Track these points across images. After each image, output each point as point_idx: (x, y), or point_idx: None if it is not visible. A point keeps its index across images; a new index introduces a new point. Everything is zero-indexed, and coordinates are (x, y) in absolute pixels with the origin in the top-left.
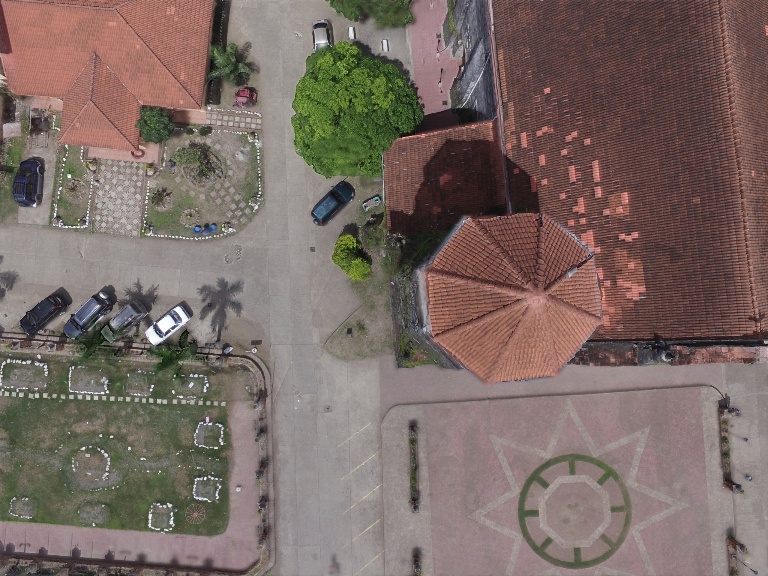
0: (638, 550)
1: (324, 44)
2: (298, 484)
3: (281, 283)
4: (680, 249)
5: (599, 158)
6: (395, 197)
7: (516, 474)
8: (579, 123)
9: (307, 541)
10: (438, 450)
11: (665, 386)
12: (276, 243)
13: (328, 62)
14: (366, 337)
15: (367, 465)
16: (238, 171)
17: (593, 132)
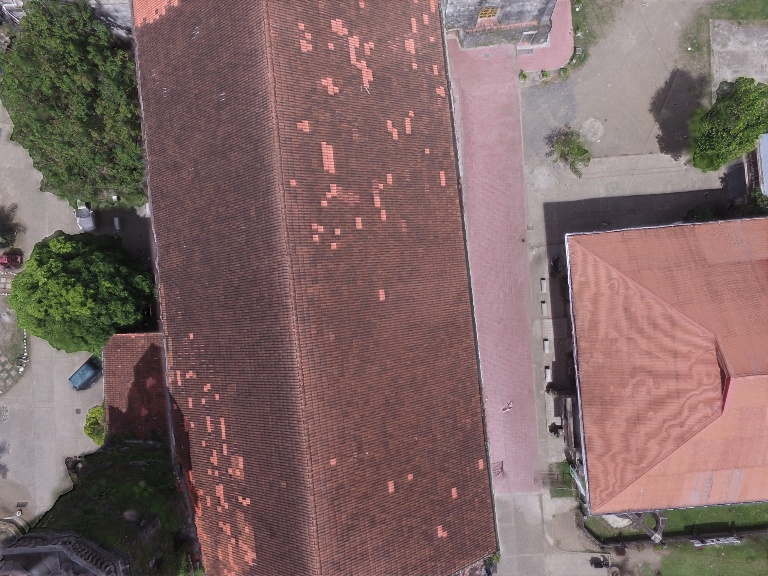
0: None
1: (83, 210)
2: None
3: (46, 445)
4: (275, 527)
5: (224, 416)
6: (111, 393)
7: None
8: (211, 376)
9: None
10: None
11: None
12: (42, 405)
13: (31, 266)
14: None
15: None
16: (4, 332)
17: (220, 389)
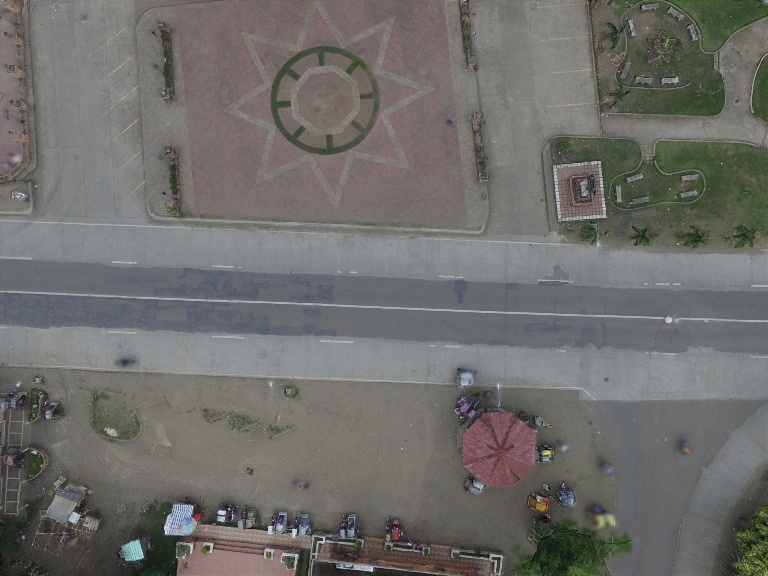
0: (387, 134)
1: None
2: (57, 89)
3: None
4: None
5: None
6: None
7: (268, 68)
8: None
9: (68, 143)
10: (191, 49)
11: None
12: None
13: None
14: None
15: (124, 68)
16: None
17: None
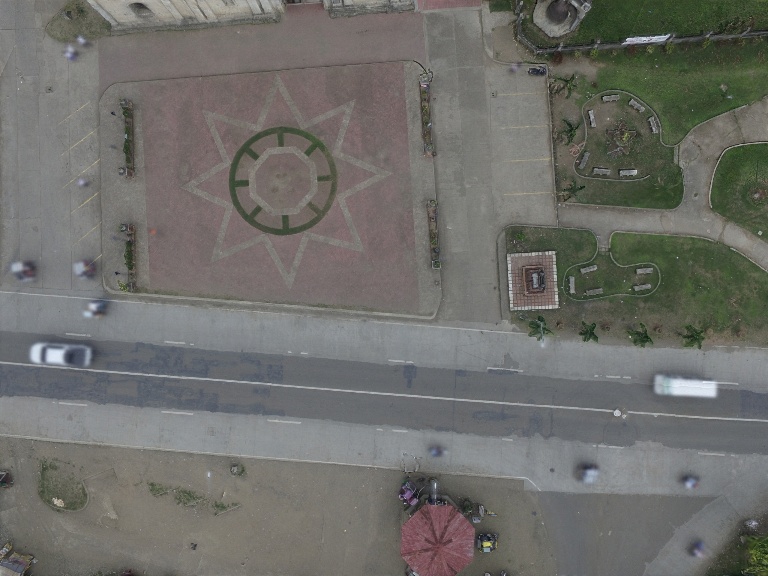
0: (343, 216)
1: None
2: (20, 160)
3: None
4: None
5: None
6: None
7: (227, 146)
8: None
9: (28, 214)
10: (153, 125)
11: (371, 62)
12: None
13: None
14: (85, 19)
15: (86, 141)
16: None
17: None
